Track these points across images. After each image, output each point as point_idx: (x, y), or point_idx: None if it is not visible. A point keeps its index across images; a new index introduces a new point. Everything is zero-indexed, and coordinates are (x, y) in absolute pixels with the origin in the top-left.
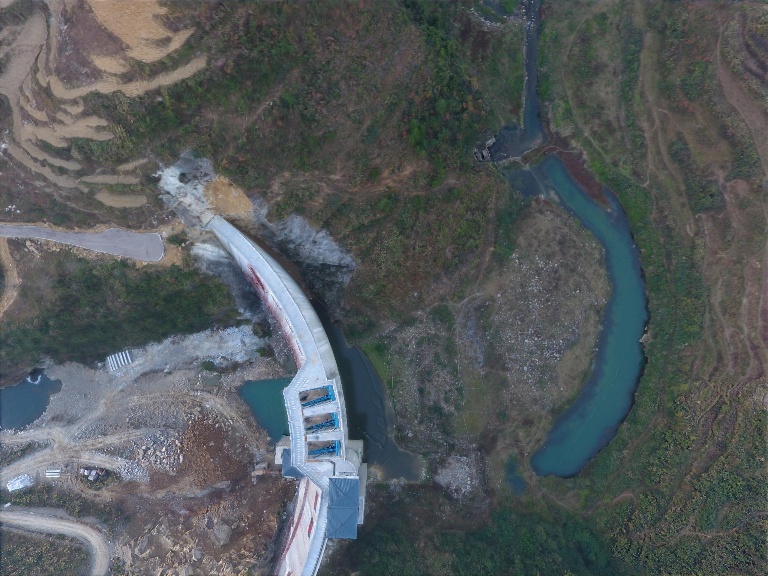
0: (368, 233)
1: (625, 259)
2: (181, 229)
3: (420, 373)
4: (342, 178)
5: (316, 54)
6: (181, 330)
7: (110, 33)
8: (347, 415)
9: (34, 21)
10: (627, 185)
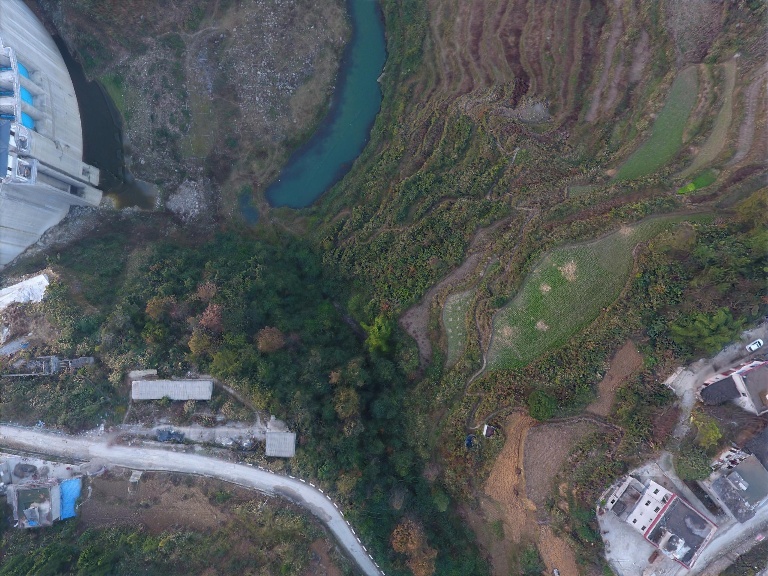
0: None
1: (368, 4)
2: None
3: (152, 101)
4: None
5: None
6: None
7: None
8: (96, 157)
9: None
10: None
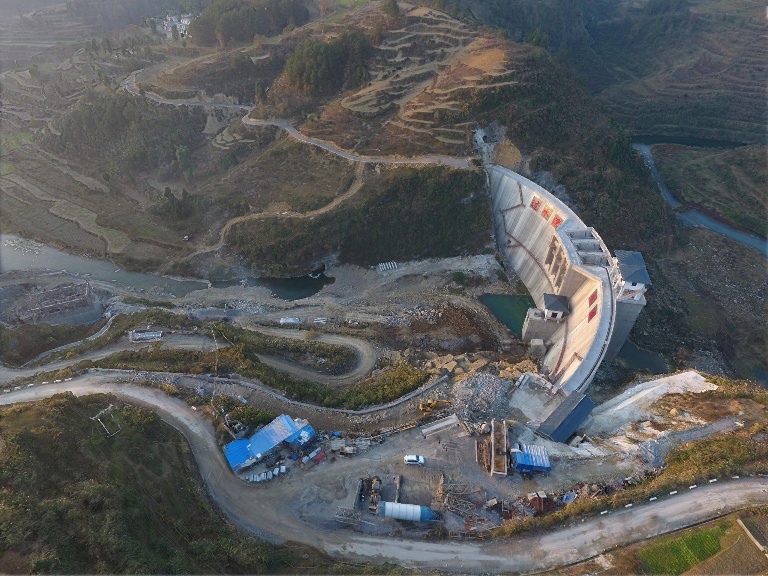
0: (589, 191)
1: None
2: (480, 158)
3: None
4: (573, 159)
5: (563, 100)
6: (439, 253)
7: (477, 69)
8: None
9: (426, 81)
10: (759, 221)
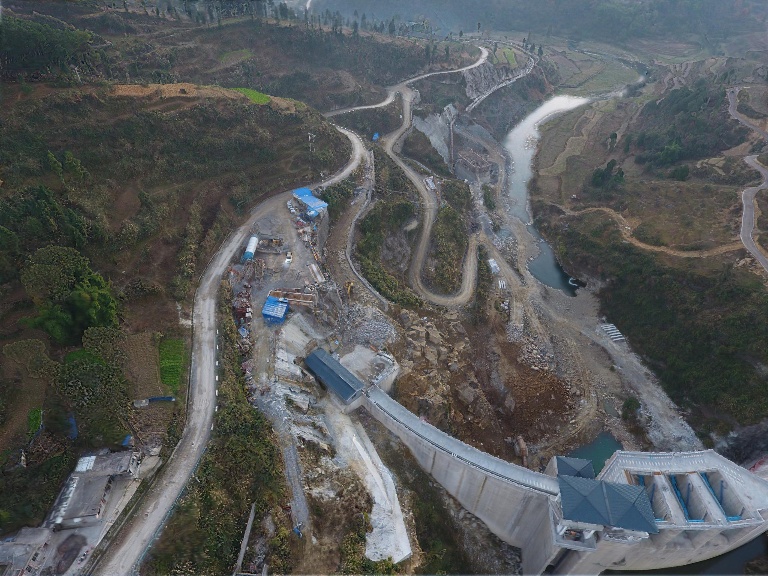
0: None
1: None
2: None
3: None
4: None
5: None
6: (666, 381)
7: None
8: None
9: None
10: None
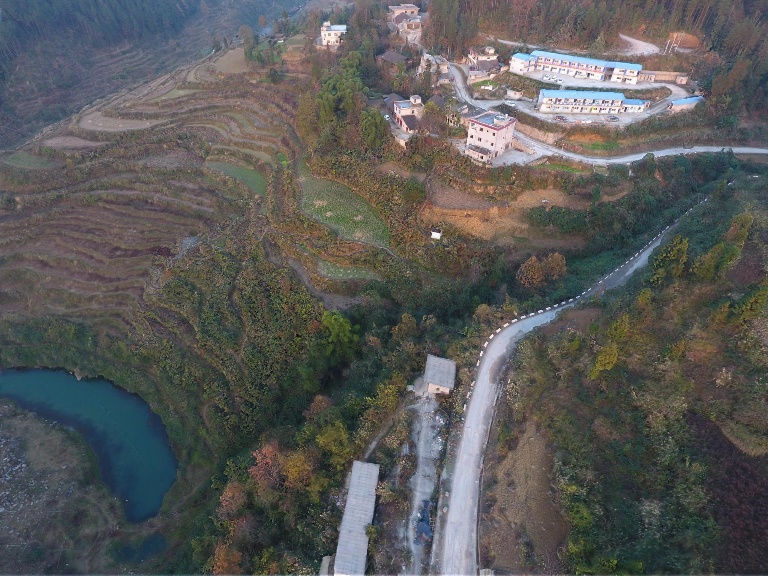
0: None
1: None
2: None
3: None
4: None
5: None
6: None
7: None
8: None
9: None
10: None
